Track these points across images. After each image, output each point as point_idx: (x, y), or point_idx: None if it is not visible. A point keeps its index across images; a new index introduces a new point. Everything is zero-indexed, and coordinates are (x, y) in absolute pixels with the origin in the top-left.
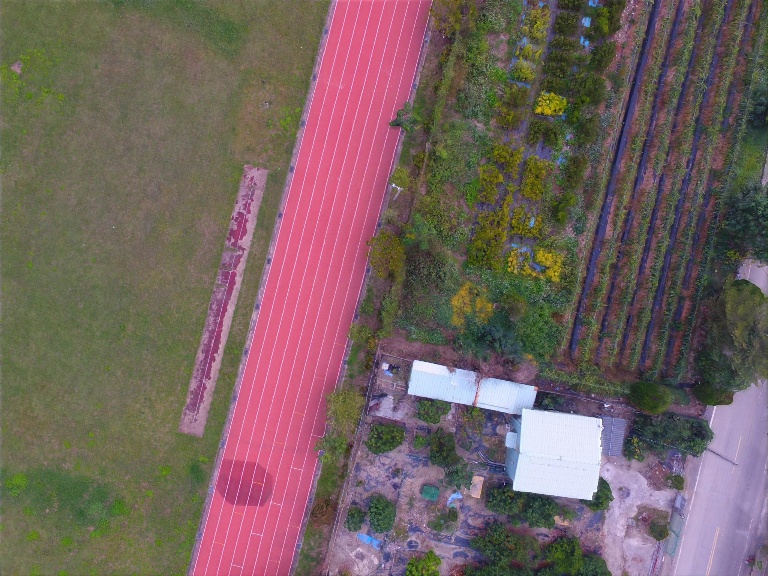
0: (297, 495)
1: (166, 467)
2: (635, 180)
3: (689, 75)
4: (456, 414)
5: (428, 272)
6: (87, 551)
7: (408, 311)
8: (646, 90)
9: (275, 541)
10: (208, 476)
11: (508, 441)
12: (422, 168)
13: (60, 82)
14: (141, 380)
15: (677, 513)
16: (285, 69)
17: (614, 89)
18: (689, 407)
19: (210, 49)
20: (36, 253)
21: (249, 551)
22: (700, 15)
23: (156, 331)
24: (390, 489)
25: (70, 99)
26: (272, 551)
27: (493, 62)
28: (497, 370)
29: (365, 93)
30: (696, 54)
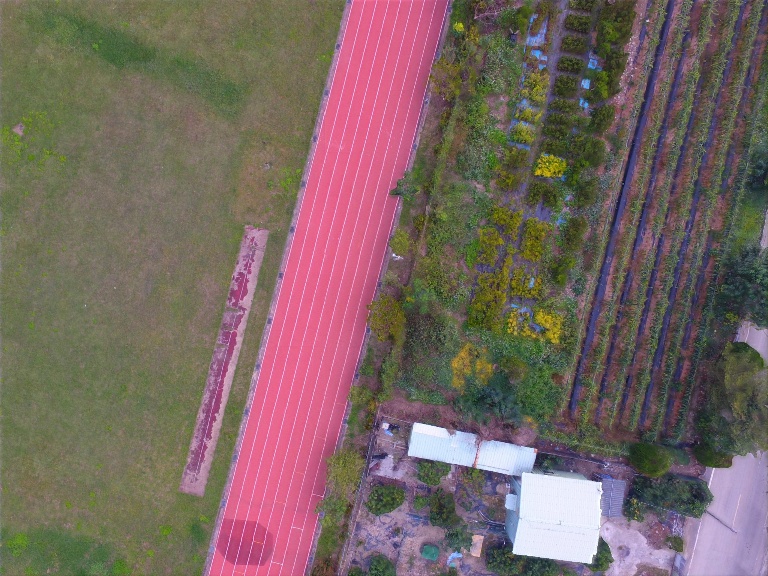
0: (297, 554)
1: (167, 527)
2: (634, 241)
3: (688, 137)
4: (456, 473)
5: (428, 334)
6: None
7: (408, 373)
8: (645, 153)
9: None
10: (209, 535)
11: (508, 503)
12: (422, 231)
13: (62, 144)
14: (142, 440)
15: (677, 572)
16: (286, 130)
17: (613, 151)
18: (688, 467)
19: (211, 111)
20: (38, 314)
21: None
22: (699, 77)
23: (157, 391)
24: (390, 548)
25: (72, 161)
26: None
27: (493, 124)
28: (497, 434)
29: (365, 154)
30: (695, 116)
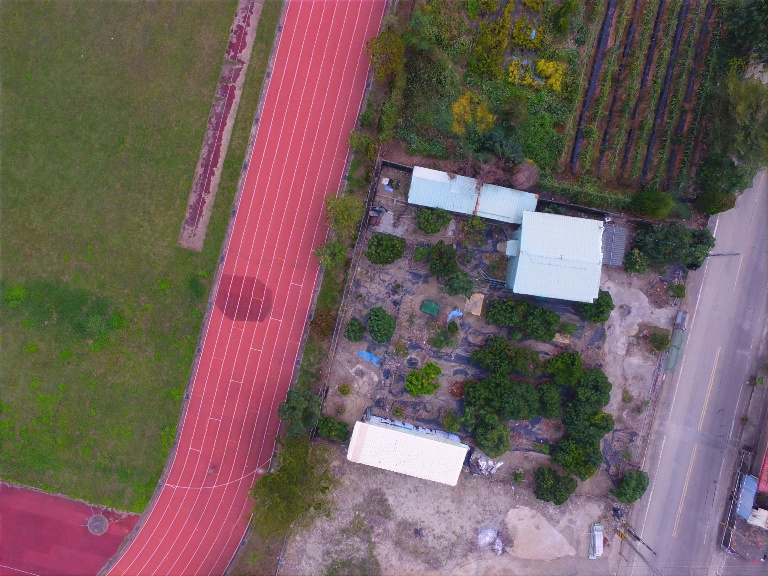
0: (297, 311)
1: (165, 281)
2: None
3: None
4: (456, 230)
5: (428, 78)
6: (86, 364)
7: (408, 120)
8: None
9: (274, 357)
10: (207, 291)
11: (509, 249)
12: None
13: None
14: (140, 193)
15: (678, 331)
16: None
17: None
18: (691, 222)
19: None
20: (34, 64)
21: (248, 366)
22: None
23: (155, 144)
24: (390, 306)
25: None
26: (271, 367)
27: None
28: (498, 172)
29: None
30: None
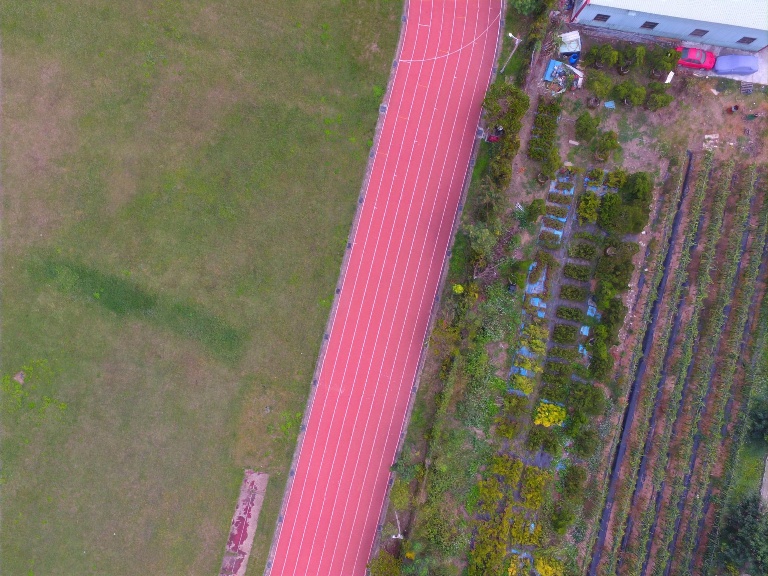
0: None
1: None
2: None
3: (687, 383)
4: None
5: None
6: None
7: None
8: (645, 407)
9: None
10: None
11: None
12: (422, 486)
13: (62, 391)
14: None
15: None
16: (286, 374)
17: (613, 398)
18: None
19: (211, 356)
20: (37, 561)
21: None
22: (698, 323)
23: None
24: None
25: (72, 408)
26: None
27: (492, 371)
28: None
29: (365, 397)
30: (694, 363)
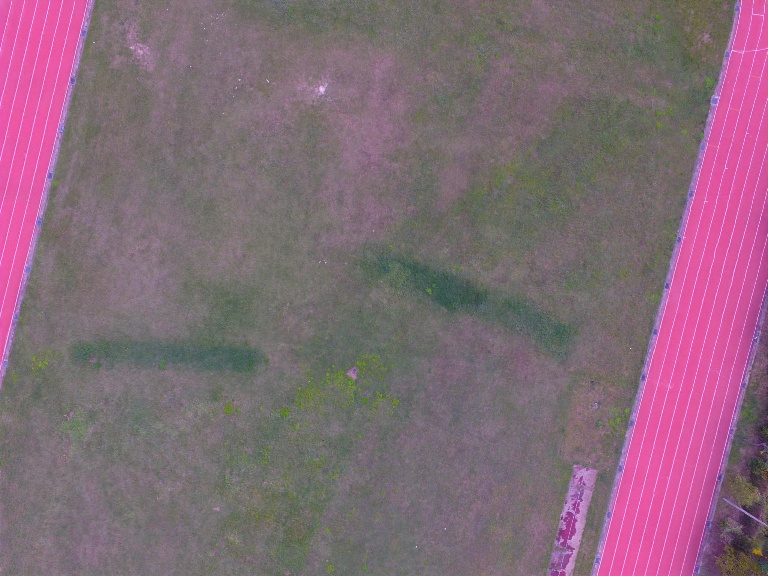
0: None
1: None
2: None
3: None
4: None
5: None
6: None
7: None
8: None
9: None
10: None
11: None
12: (767, 482)
13: (394, 387)
14: None
15: None
16: (615, 370)
17: None
18: None
19: (541, 352)
20: (370, 555)
21: None
22: None
23: None
24: None
25: (404, 404)
26: None
27: None
28: None
29: (695, 393)
30: None
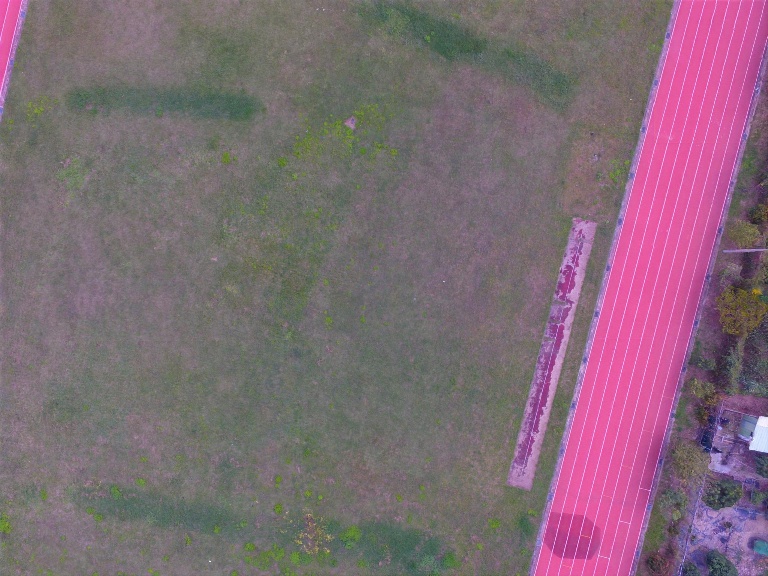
0: (625, 548)
1: (496, 520)
2: None
3: None
4: None
5: None
6: None
7: (748, 366)
8: None
9: None
10: (536, 529)
11: None
12: (767, 222)
13: (392, 137)
14: (471, 433)
15: None
16: (615, 121)
17: None
18: None
19: (541, 102)
20: (368, 308)
21: None
22: None
23: (485, 385)
24: (717, 542)
25: (403, 154)
26: None
27: None
28: None
29: (695, 144)
30: None
